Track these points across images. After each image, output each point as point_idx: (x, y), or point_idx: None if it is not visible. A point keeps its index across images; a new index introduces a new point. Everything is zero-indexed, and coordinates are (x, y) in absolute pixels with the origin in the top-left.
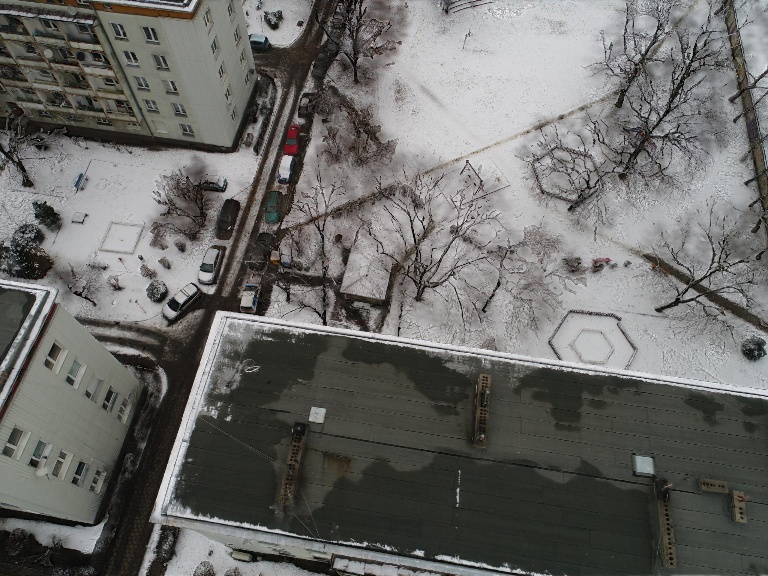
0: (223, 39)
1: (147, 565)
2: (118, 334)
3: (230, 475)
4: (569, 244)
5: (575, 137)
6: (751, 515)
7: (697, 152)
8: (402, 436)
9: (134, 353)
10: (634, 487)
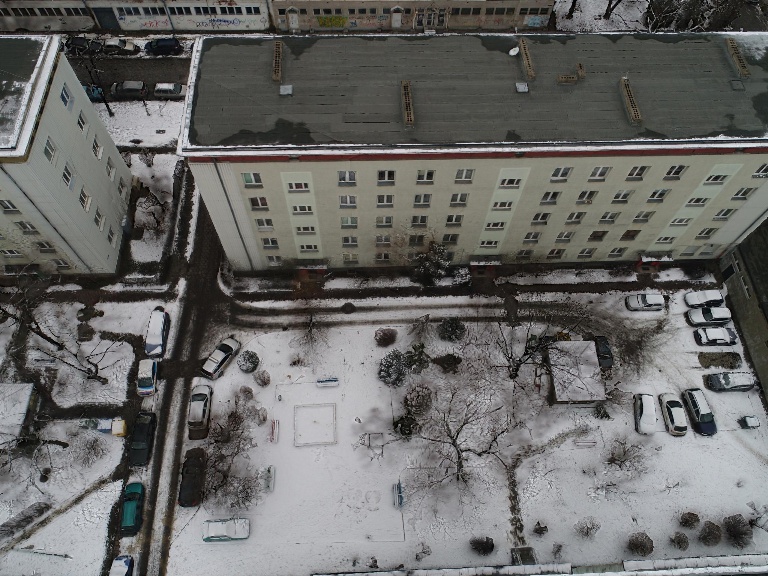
0: None
1: None
2: (280, 319)
3: (4, 56)
4: None
5: None
6: None
7: None
8: None
9: (257, 303)
10: None
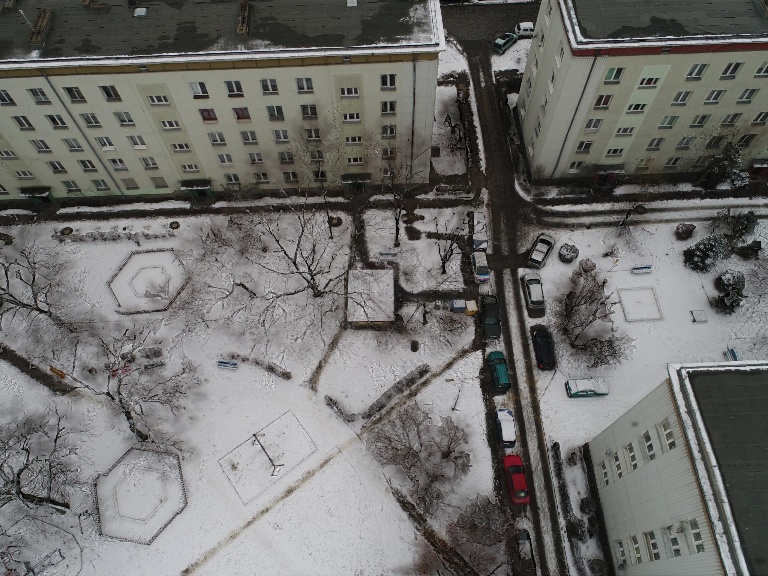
0: (652, 483)
1: (471, 95)
2: (582, 219)
3: None
4: None
5: (116, 575)
6: (81, 2)
7: None
8: (295, 2)
9: (558, 207)
10: (150, 3)
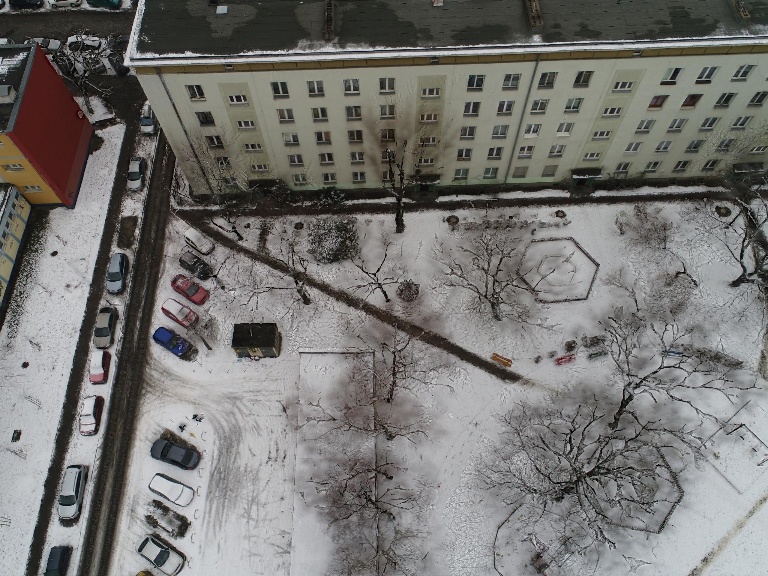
0: None
1: None
2: None
3: None
4: (604, 377)
5: None
6: None
7: (457, 571)
8: None
9: None
10: None
